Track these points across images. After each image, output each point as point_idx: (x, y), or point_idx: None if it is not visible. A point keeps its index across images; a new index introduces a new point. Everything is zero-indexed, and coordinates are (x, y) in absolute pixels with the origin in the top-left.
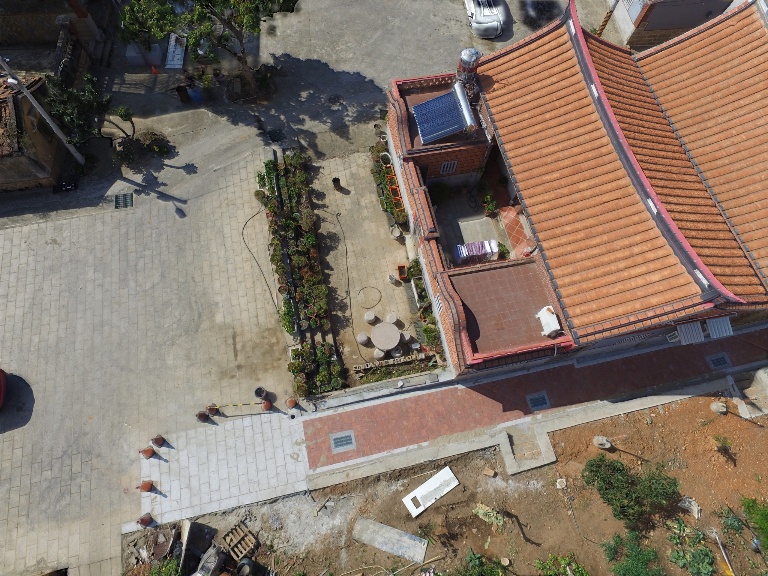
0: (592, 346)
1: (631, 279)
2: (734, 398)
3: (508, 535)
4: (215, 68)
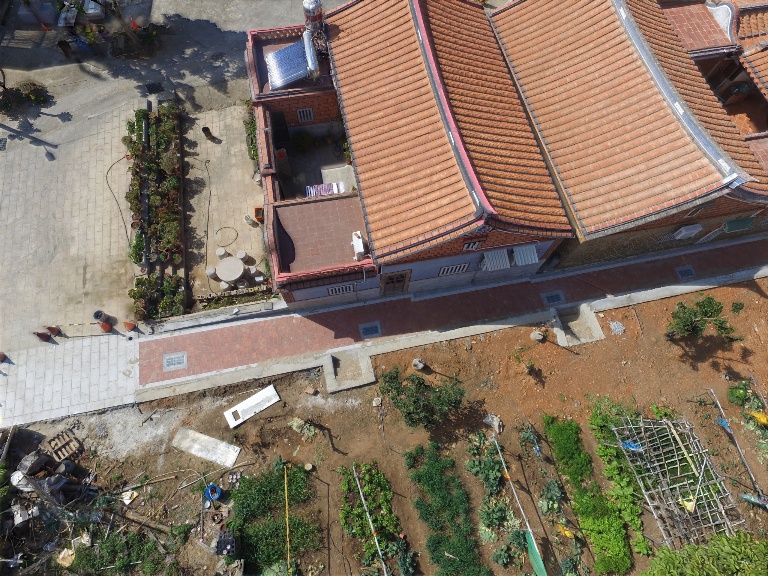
0: (413, 275)
1: (427, 204)
2: (555, 328)
3: (317, 445)
4: (105, 26)
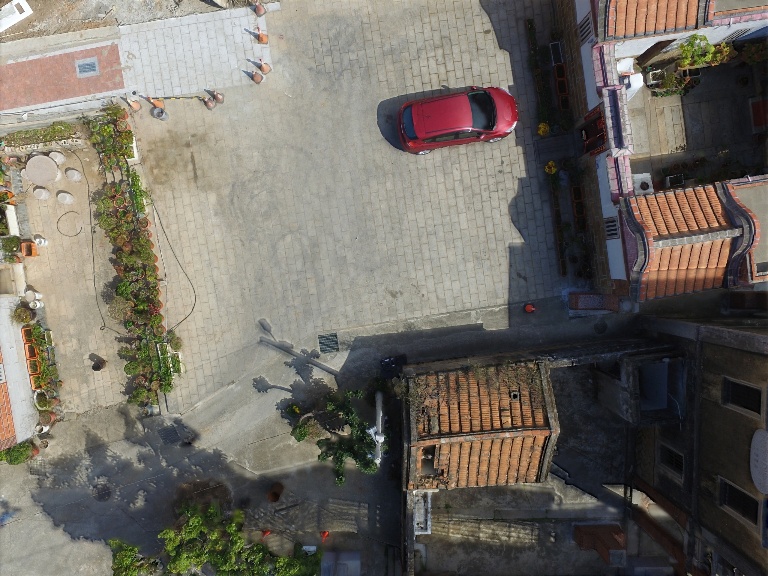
0: None
1: None
2: None
3: None
4: None
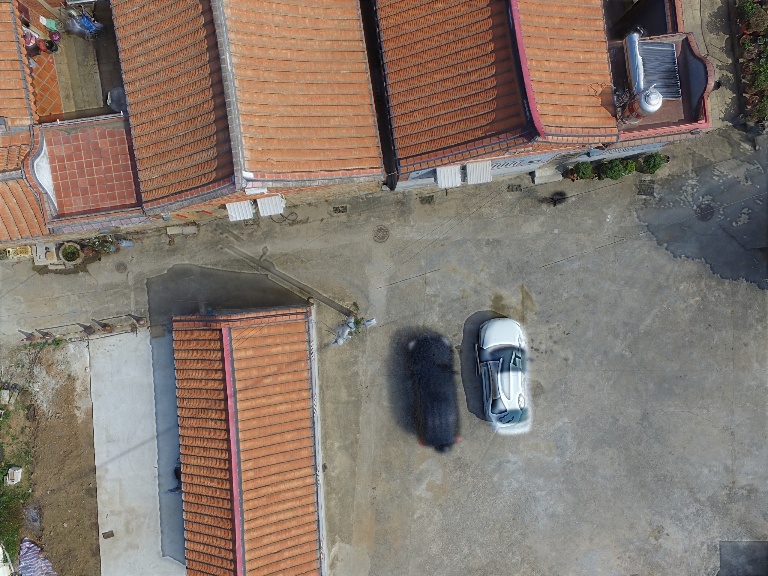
0: None
1: None
2: None
3: None
4: None
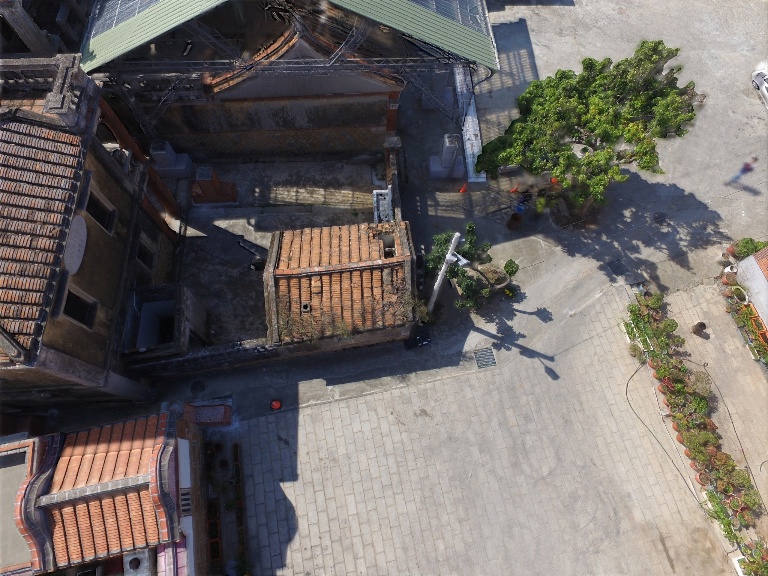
0: None
1: None
2: None
3: None
4: None
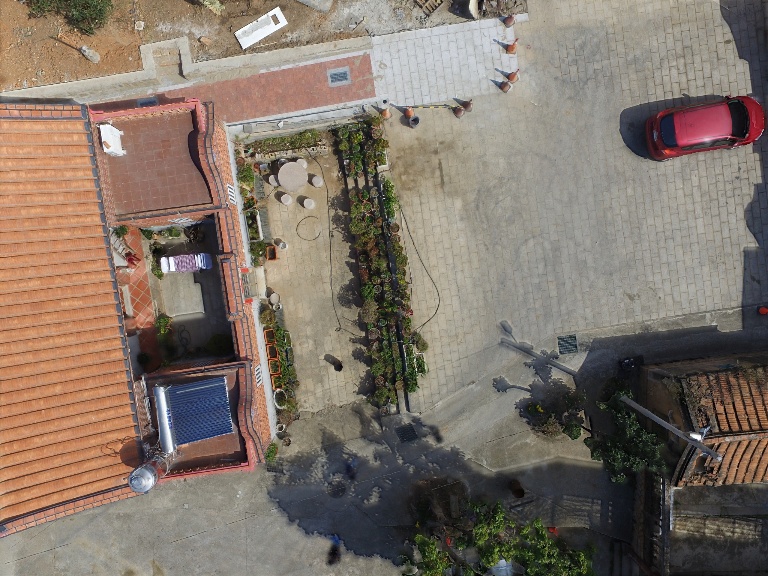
0: None
1: (6, 158)
2: None
3: None
4: None
